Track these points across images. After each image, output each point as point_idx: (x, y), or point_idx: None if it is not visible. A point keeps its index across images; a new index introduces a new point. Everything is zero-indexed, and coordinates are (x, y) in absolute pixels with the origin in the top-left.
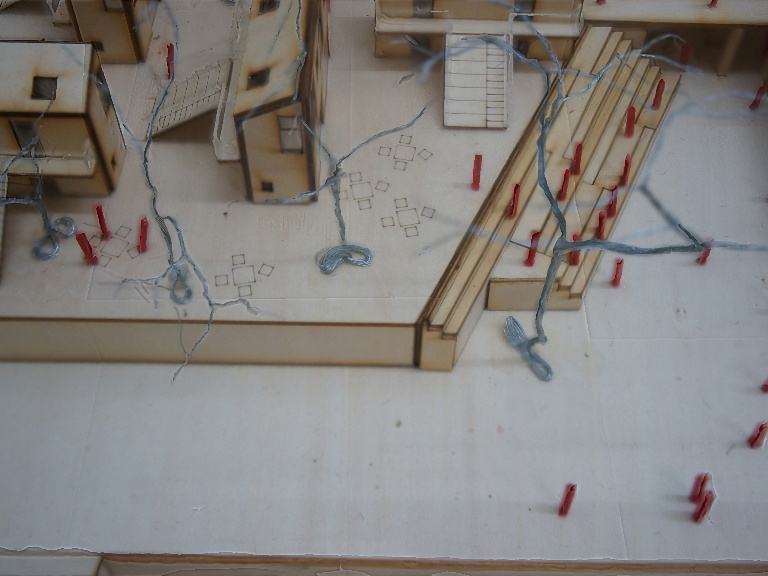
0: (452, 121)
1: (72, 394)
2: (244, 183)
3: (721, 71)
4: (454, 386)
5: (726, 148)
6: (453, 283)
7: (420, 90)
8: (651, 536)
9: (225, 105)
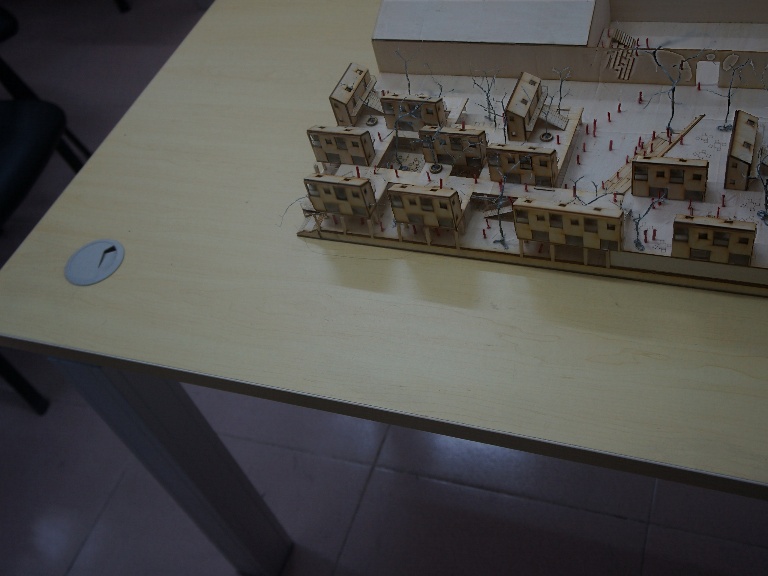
0: None
1: None
2: None
3: None
4: None
5: None
6: None
7: None
8: None
9: None
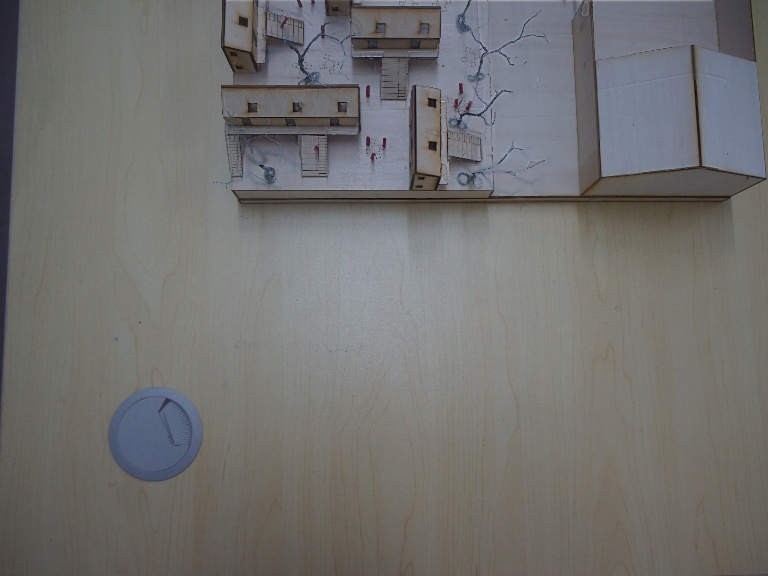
0: None
1: (500, 126)
2: None
3: None
4: (490, 2)
5: None
6: None
7: None
8: None
9: None
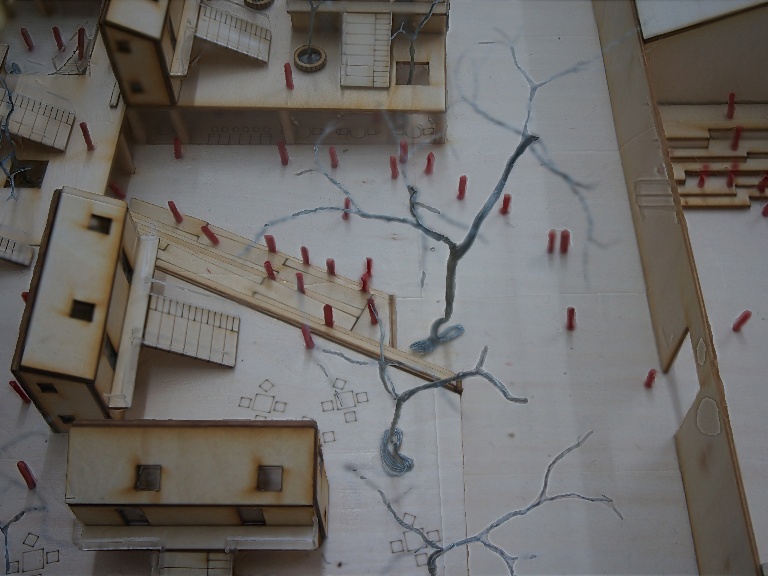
0: (230, 359)
1: None
2: (319, 538)
3: (132, 169)
4: (473, 395)
5: (224, 182)
6: None
7: (177, 389)
8: (581, 279)
9: (237, 549)
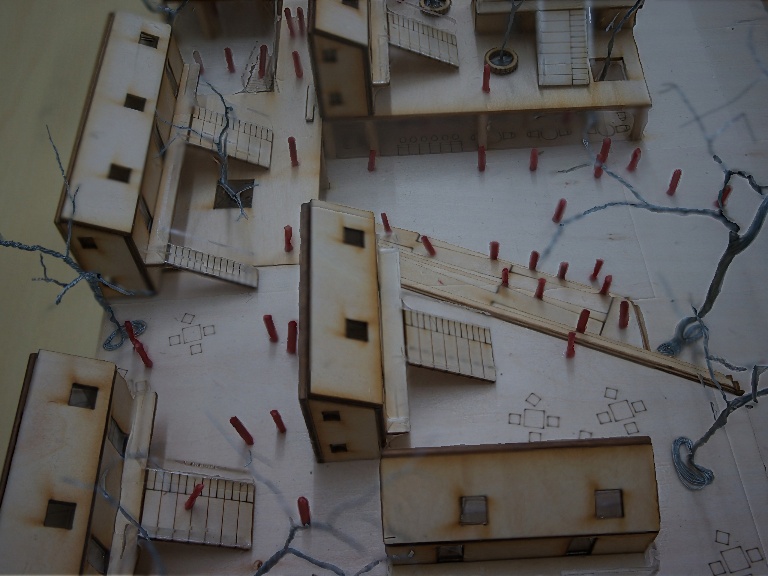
0: (491, 373)
1: None
2: None
3: (328, 184)
4: None
5: (423, 192)
6: None
7: (439, 409)
8: None
9: None
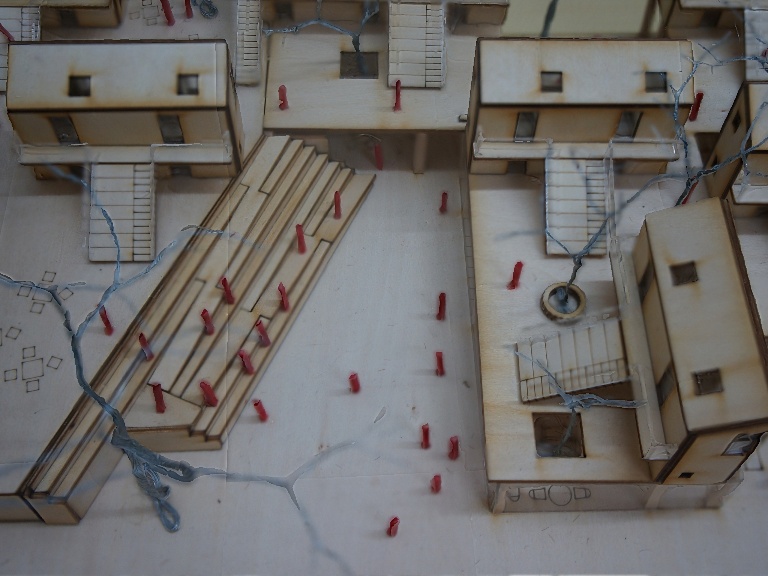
0: (97, 256)
1: None
2: None
3: (417, 169)
4: (78, 541)
5: (407, 257)
6: (67, 442)
7: (75, 217)
8: None
9: None
